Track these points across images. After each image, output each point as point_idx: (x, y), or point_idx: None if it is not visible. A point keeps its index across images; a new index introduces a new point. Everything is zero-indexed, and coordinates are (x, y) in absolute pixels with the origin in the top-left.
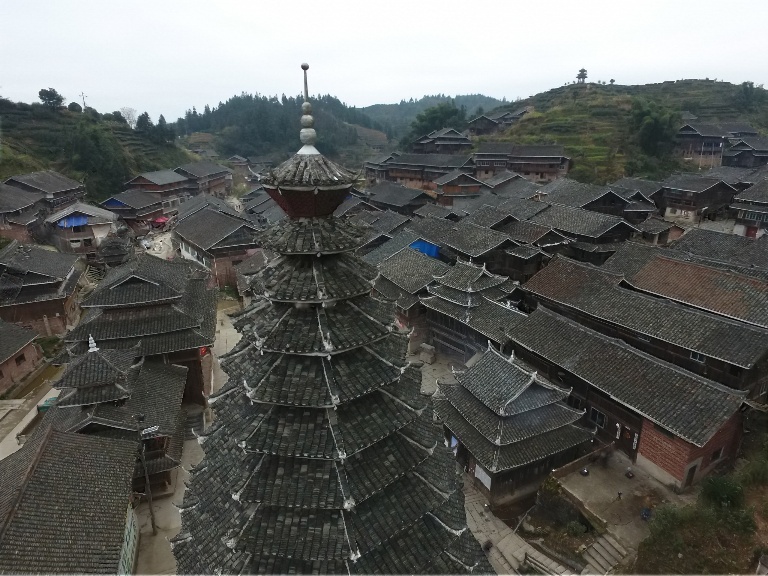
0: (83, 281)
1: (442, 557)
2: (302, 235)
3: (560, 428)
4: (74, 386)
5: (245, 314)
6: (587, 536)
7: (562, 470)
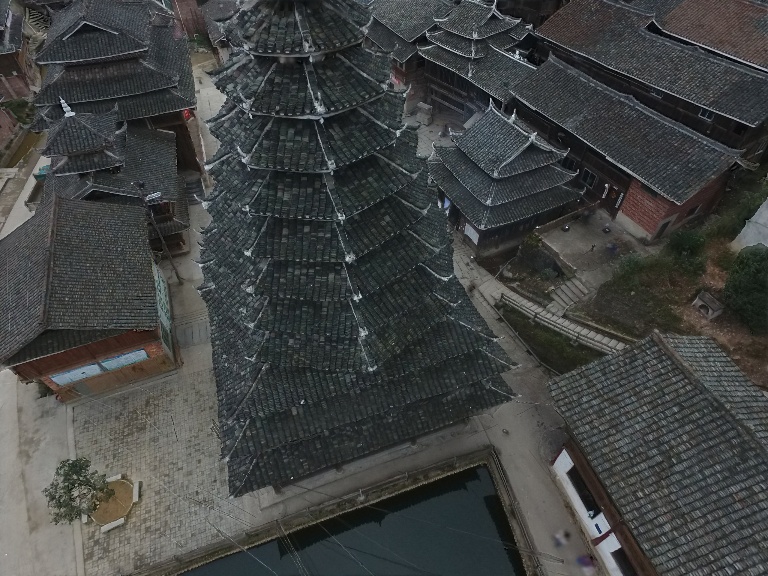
0: (28, 30)
1: (431, 297)
2: None
3: (550, 189)
4: (63, 154)
5: (225, 71)
6: (557, 280)
7: (545, 227)
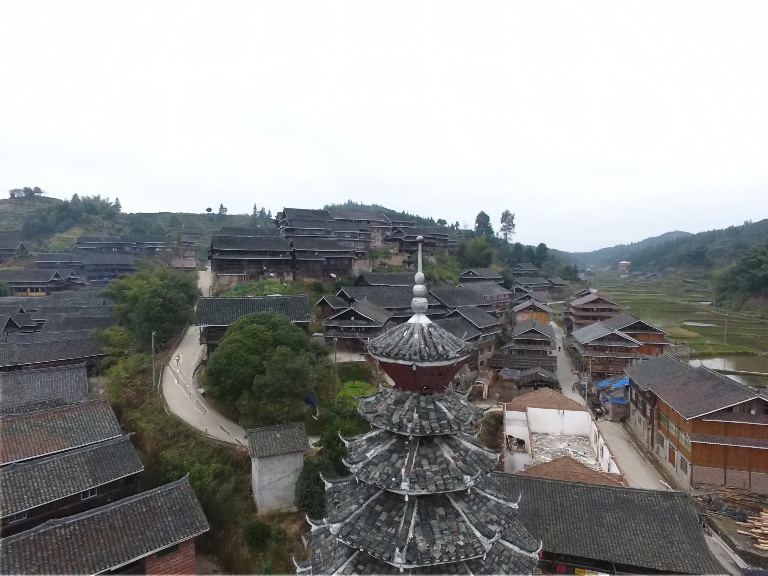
0: None
1: None
2: None
3: None
4: None
5: None
6: None
7: None
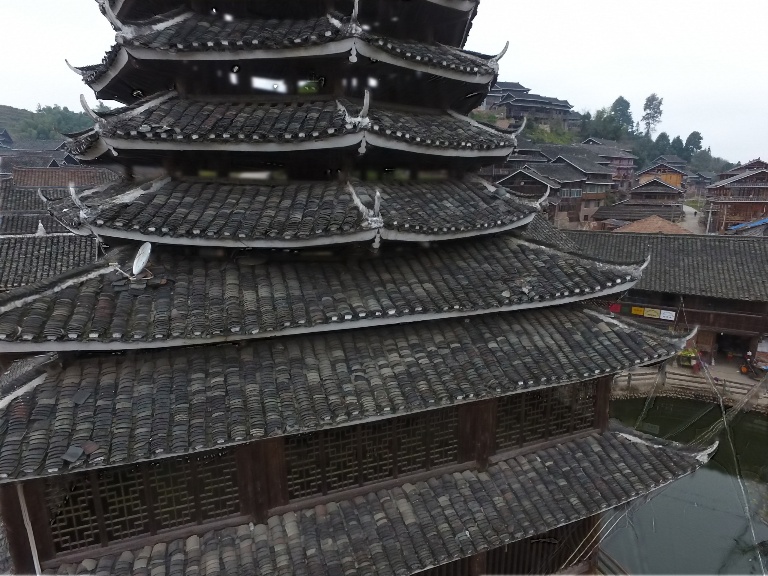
0: None
1: None
2: None
3: None
4: None
5: None
6: None
7: None
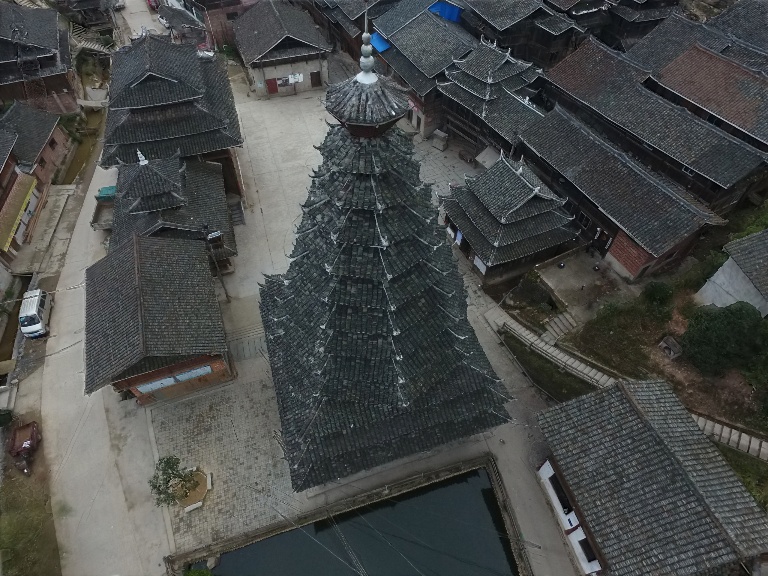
0: (71, 42)
1: None
2: (363, 156)
3: (550, 230)
4: None
5: (315, 205)
6: (551, 312)
7: (544, 264)
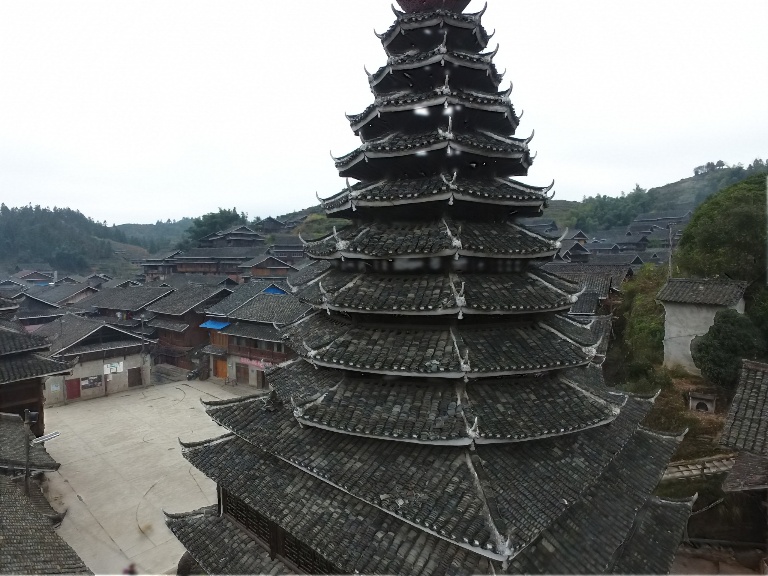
0: None
1: None
2: None
3: None
4: None
5: (389, 97)
6: None
7: None
